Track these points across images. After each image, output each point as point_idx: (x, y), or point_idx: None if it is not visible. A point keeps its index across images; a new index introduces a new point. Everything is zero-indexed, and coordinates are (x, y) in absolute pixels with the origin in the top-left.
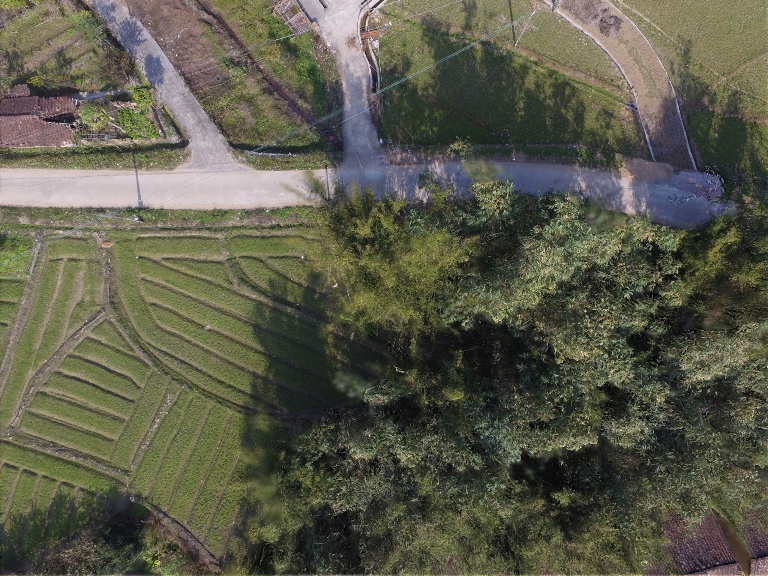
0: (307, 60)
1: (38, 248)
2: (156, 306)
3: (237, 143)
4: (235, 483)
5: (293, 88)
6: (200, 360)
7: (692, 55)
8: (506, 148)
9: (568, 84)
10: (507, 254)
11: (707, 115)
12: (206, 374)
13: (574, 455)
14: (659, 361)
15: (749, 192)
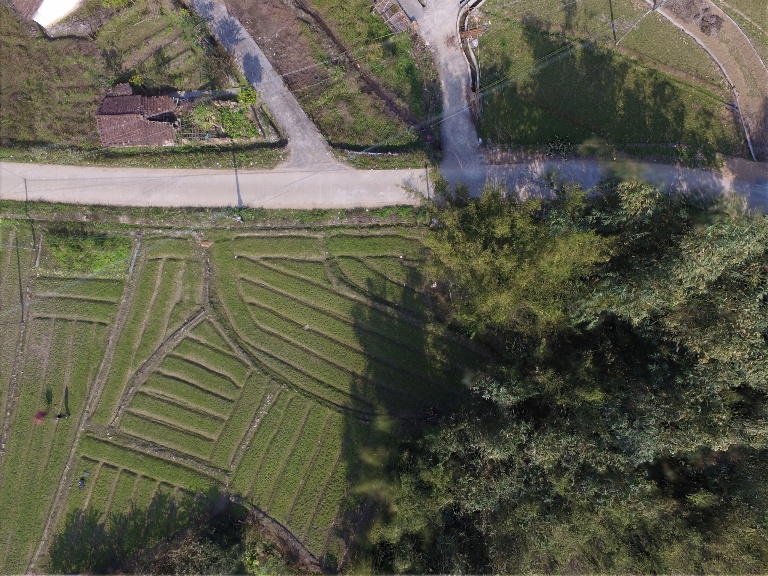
0: (406, 59)
1: (138, 247)
2: (255, 306)
3: (335, 142)
4: (335, 483)
5: (391, 87)
6: (299, 360)
7: None
8: (606, 147)
9: (668, 83)
10: (655, 254)
11: None
12: (305, 374)
13: (695, 455)
14: None
15: None
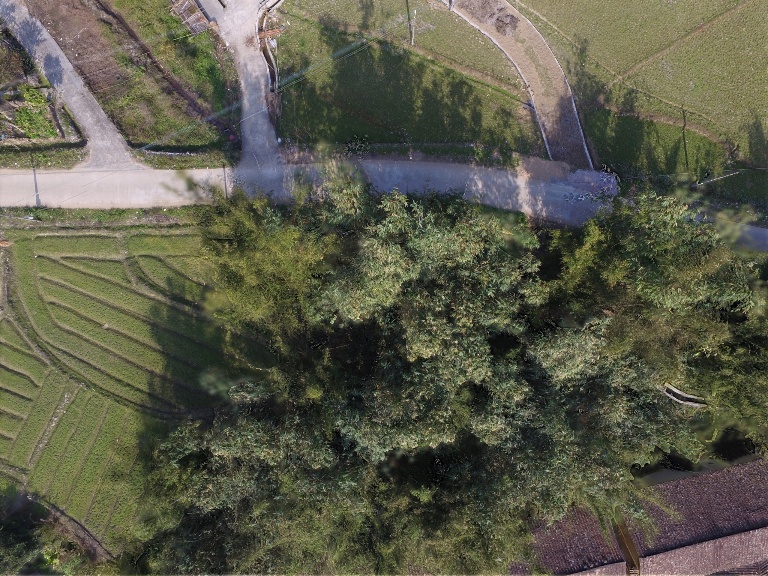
0: (206, 59)
1: None
2: (54, 305)
3: (136, 142)
4: (132, 482)
5: (193, 87)
6: (98, 359)
7: (588, 54)
8: (403, 147)
9: (465, 83)
10: (355, 252)
11: (604, 114)
12: (104, 373)
13: (450, 453)
14: (526, 359)
15: (645, 190)
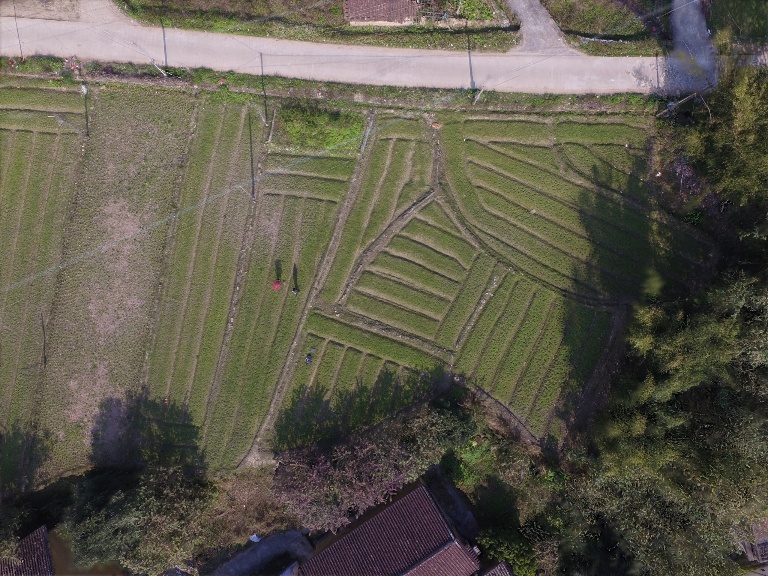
0: None
1: (370, 126)
2: (483, 189)
3: (565, 29)
4: (559, 366)
5: None
6: (526, 244)
7: None
8: None
9: None
10: None
11: None
12: (531, 258)
13: None
14: None
15: None
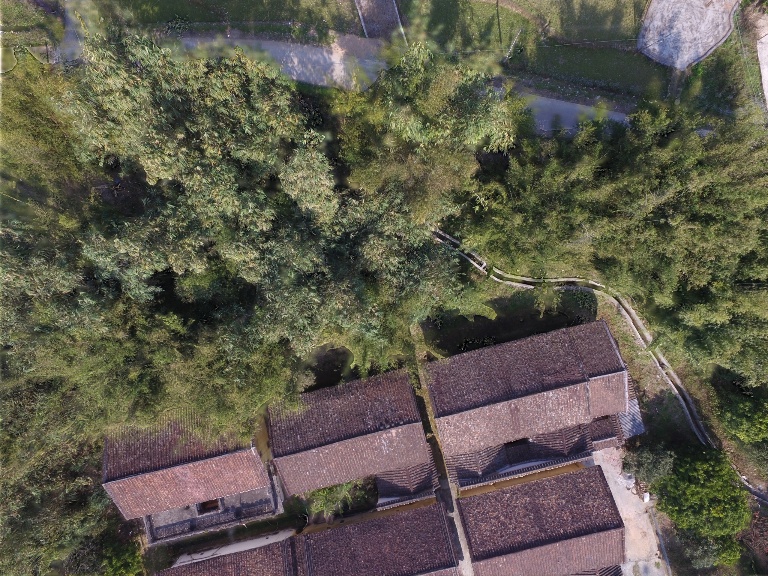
0: None
1: None
2: None
3: None
4: None
5: None
6: None
7: None
8: (221, 25)
9: None
10: None
11: None
12: None
13: (228, 301)
14: None
15: None
